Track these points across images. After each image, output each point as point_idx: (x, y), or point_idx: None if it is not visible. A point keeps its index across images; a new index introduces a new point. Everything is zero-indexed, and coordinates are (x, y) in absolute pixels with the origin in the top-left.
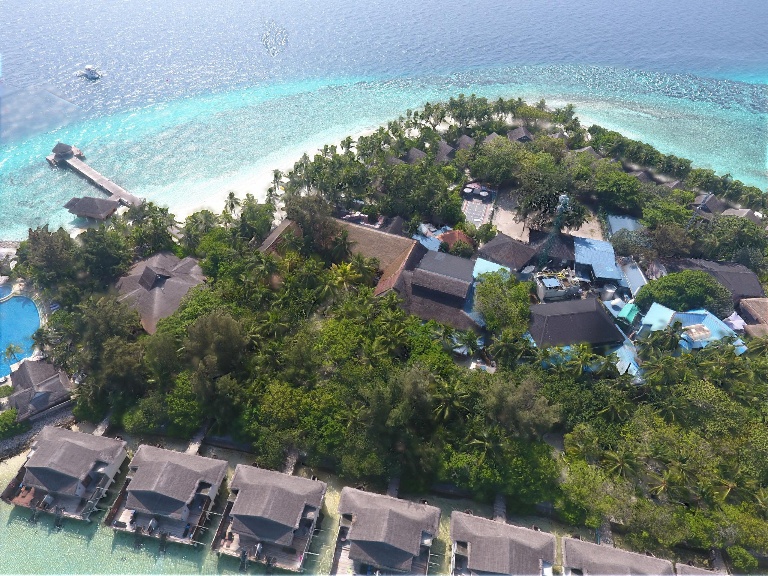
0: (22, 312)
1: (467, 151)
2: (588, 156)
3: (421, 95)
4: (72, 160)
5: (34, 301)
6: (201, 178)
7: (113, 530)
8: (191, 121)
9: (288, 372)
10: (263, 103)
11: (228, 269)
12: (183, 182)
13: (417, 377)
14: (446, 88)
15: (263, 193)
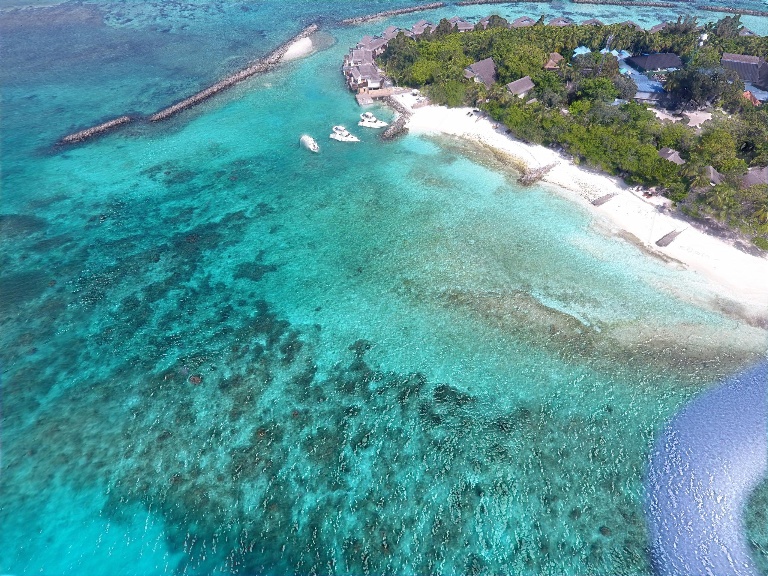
0: None
1: None
2: (675, 123)
3: None
4: None
5: None
6: None
7: None
8: None
9: None
10: None
11: None
12: None
13: (727, 21)
14: None
15: None
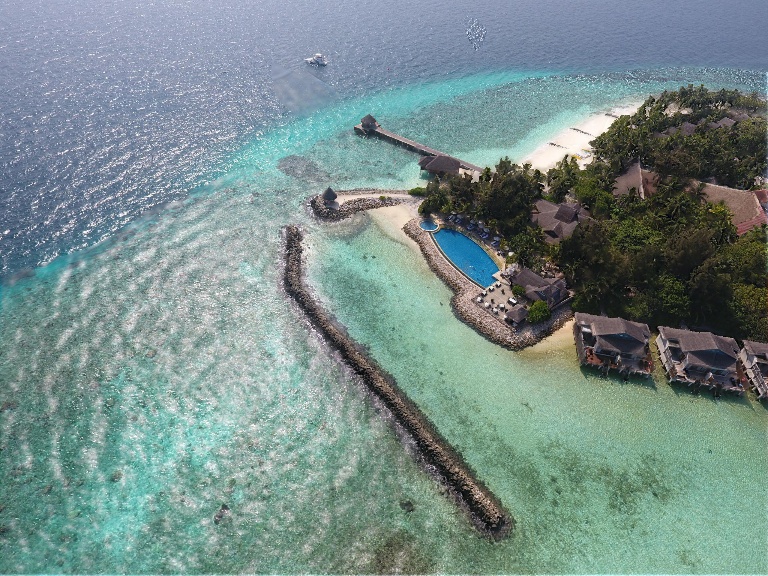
0: (458, 240)
1: (726, 130)
2: None
3: (616, 88)
4: (379, 130)
5: (461, 232)
6: (493, 148)
7: (667, 384)
8: (439, 103)
9: (755, 276)
10: (486, 90)
11: (624, 209)
12: (481, 150)
13: None
14: (632, 83)
15: (561, 160)
